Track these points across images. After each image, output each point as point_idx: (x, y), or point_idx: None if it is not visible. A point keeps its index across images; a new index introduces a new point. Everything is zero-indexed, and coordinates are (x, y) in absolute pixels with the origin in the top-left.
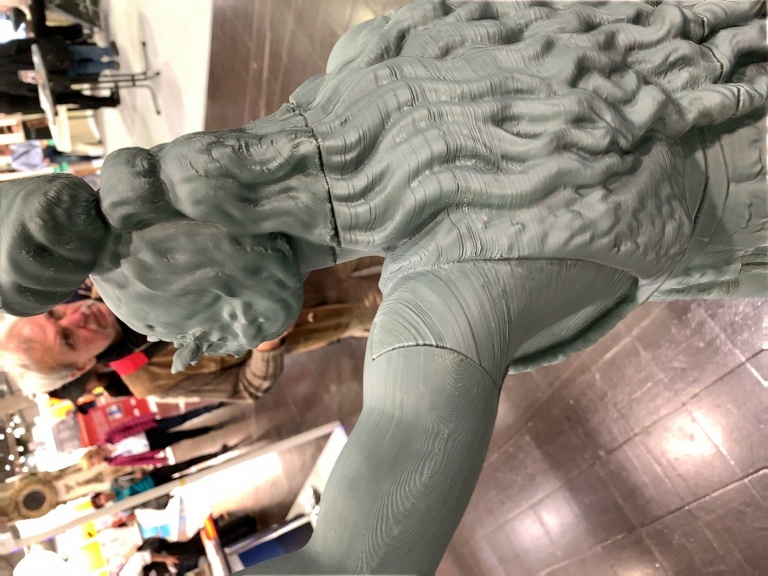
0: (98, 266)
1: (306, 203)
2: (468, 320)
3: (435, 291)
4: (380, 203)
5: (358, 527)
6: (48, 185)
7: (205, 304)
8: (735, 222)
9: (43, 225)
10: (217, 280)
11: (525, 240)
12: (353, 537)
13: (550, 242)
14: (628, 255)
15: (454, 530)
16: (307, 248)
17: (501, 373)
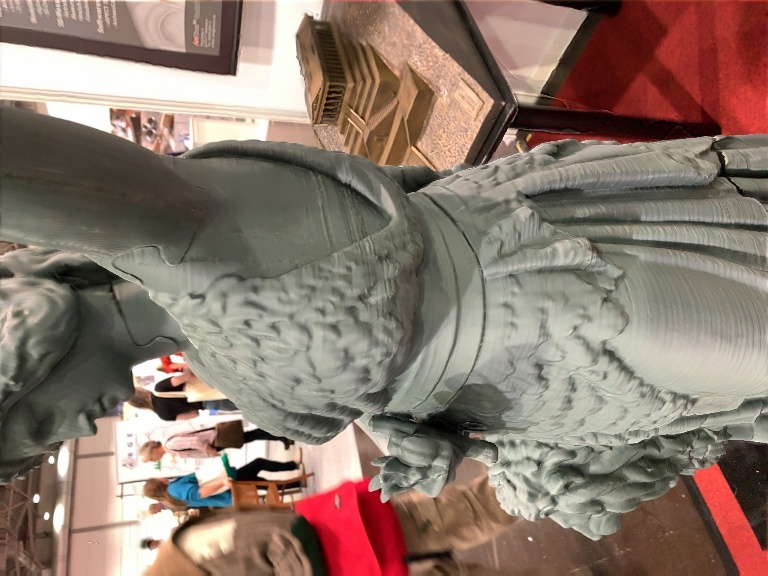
0: None
1: None
2: None
3: None
4: None
5: None
6: None
7: None
8: (467, 188)
9: None
10: None
11: None
12: None
13: None
14: None
15: None
16: (91, 298)
17: None
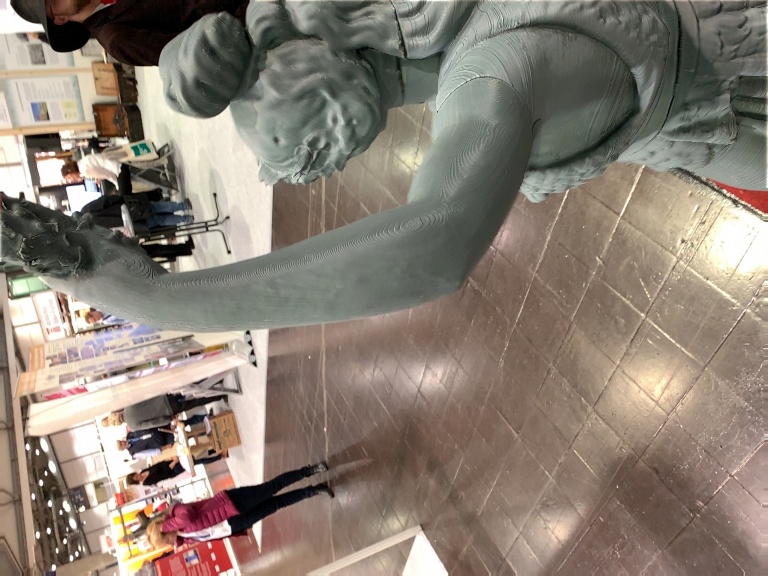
0: (243, 83)
1: (381, 21)
2: (500, 61)
3: (475, 54)
4: (431, 9)
5: (437, 177)
6: None
7: (315, 109)
8: (711, 50)
9: (216, 31)
10: (324, 81)
11: (533, 8)
12: (435, 183)
13: (551, 8)
14: (613, 27)
15: (509, 198)
16: (383, 76)
17: (531, 108)
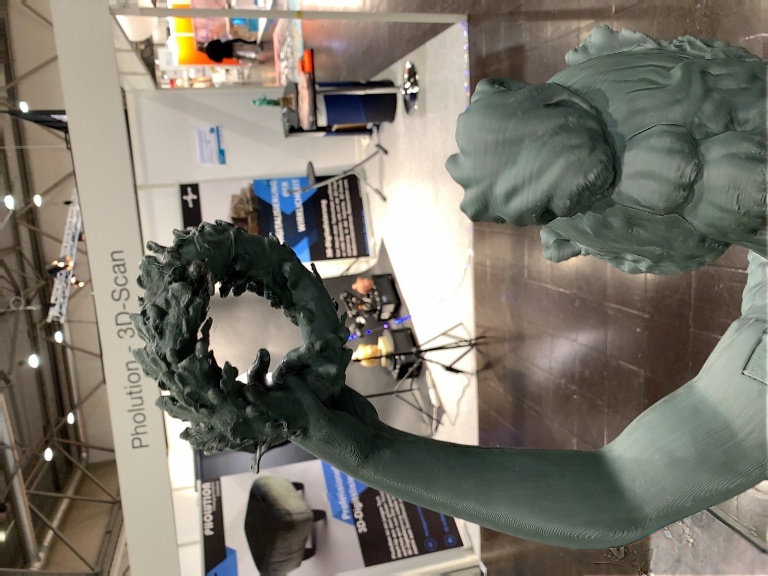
0: None
1: None
2: None
3: None
4: None
5: (665, 492)
6: (587, 159)
7: (623, 250)
8: None
9: (568, 207)
10: (658, 257)
11: None
12: (658, 495)
13: None
14: None
15: None
16: None
17: None
